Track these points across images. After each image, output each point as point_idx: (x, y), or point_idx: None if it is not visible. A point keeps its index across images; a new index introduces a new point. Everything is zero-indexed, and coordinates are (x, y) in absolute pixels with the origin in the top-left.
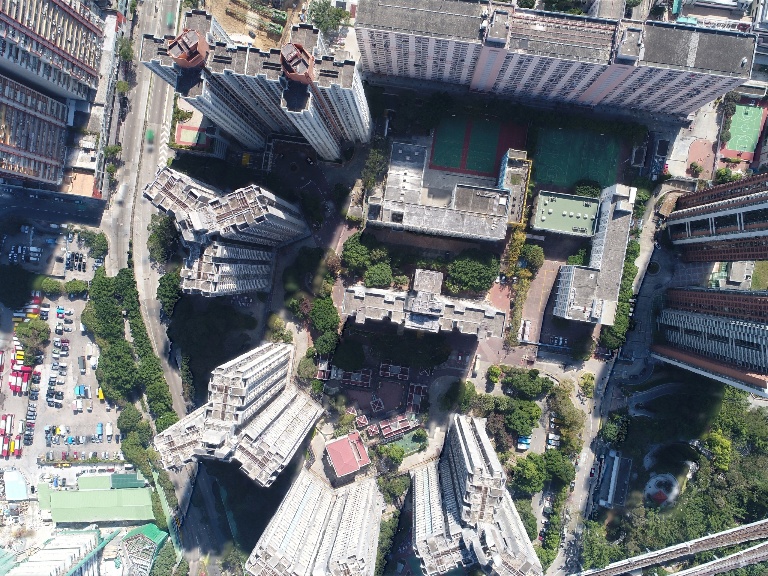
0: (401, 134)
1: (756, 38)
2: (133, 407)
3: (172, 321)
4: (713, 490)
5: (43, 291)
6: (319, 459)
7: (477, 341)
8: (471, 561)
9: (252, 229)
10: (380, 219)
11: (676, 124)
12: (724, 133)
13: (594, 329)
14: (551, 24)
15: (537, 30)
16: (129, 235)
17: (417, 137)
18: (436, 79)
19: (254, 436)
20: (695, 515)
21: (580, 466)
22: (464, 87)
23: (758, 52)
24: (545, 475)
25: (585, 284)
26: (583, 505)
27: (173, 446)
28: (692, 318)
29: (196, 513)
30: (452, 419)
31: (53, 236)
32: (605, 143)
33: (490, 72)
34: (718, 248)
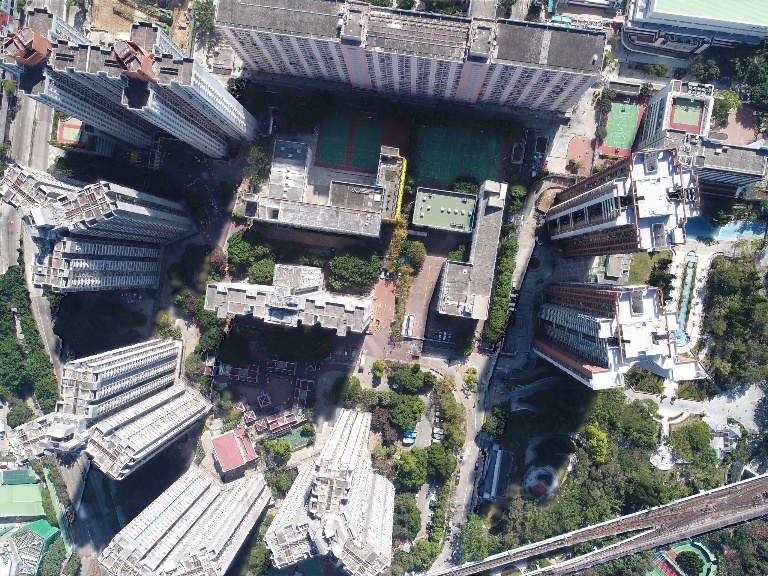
0: (286, 132)
1: (606, 36)
2: (24, 404)
3: (58, 318)
4: (589, 482)
5: None
6: (209, 454)
7: (363, 336)
8: None
9: (106, 225)
10: (257, 216)
11: (555, 121)
12: (600, 130)
13: (477, 324)
14: (407, 22)
15: (393, 28)
16: (20, 233)
17: (302, 135)
18: (318, 77)
19: (105, 430)
20: (571, 507)
21: (465, 460)
22: (348, 85)
23: (633, 50)
24: (429, 469)
25: (459, 279)
26: (468, 498)
27: (26, 440)
28: (557, 312)
29: (88, 509)
30: (338, 414)
31: None
32: (486, 140)
33: (361, 70)
34: (582, 243)
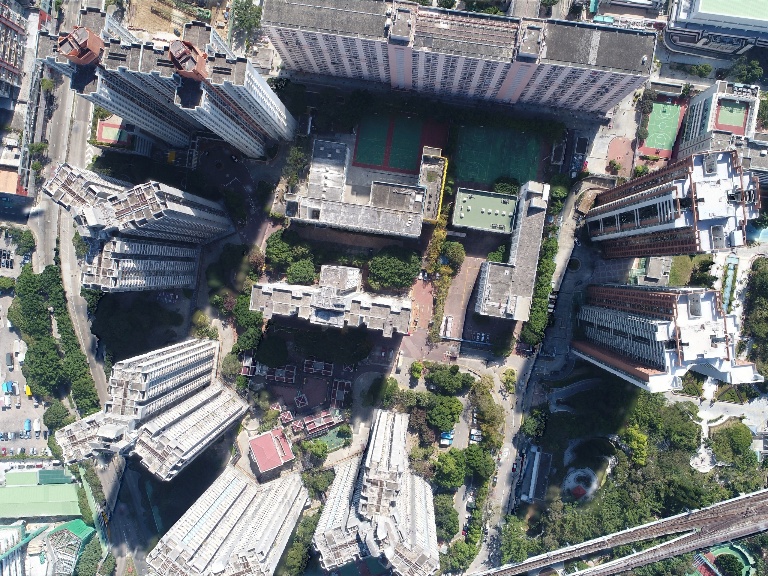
0: (325, 132)
1: (656, 36)
2: (60, 403)
3: (96, 317)
4: (629, 485)
5: None
6: (245, 455)
7: (401, 337)
8: None
9: (154, 225)
10: (298, 216)
11: (595, 122)
12: (641, 131)
13: (516, 325)
14: (455, 22)
15: (441, 28)
16: (56, 232)
17: (340, 135)
18: (357, 77)
19: (154, 430)
20: (611, 509)
21: (502, 461)
22: (387, 85)
23: (675, 51)
24: (467, 470)
25: (500, 280)
26: (506, 500)
27: (74, 440)
28: (601, 314)
29: (124, 509)
30: (375, 415)
31: None
32: (526, 141)
33: (404, 70)
34: (627, 244)
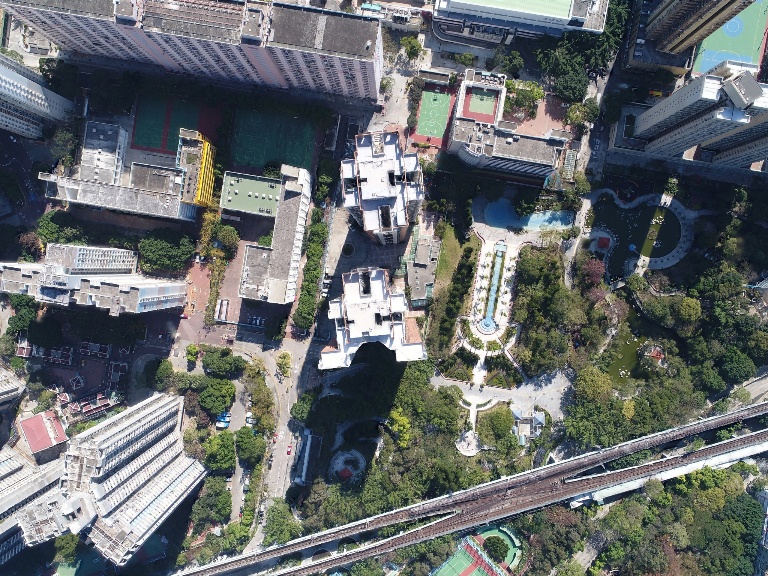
0: (103, 113)
1: (379, 22)
2: None
3: None
4: (391, 467)
5: None
6: None
7: (178, 320)
8: (68, 530)
9: None
10: (59, 196)
11: (369, 109)
12: (410, 118)
13: (291, 309)
14: (184, 3)
15: (171, 9)
16: None
17: (119, 117)
18: (132, 59)
19: None
20: (372, 491)
21: (278, 444)
22: (164, 68)
23: (444, 40)
24: (239, 452)
25: (258, 263)
26: (281, 482)
27: None
28: None
29: None
30: None
31: None
32: (301, 126)
33: (158, 52)
34: None
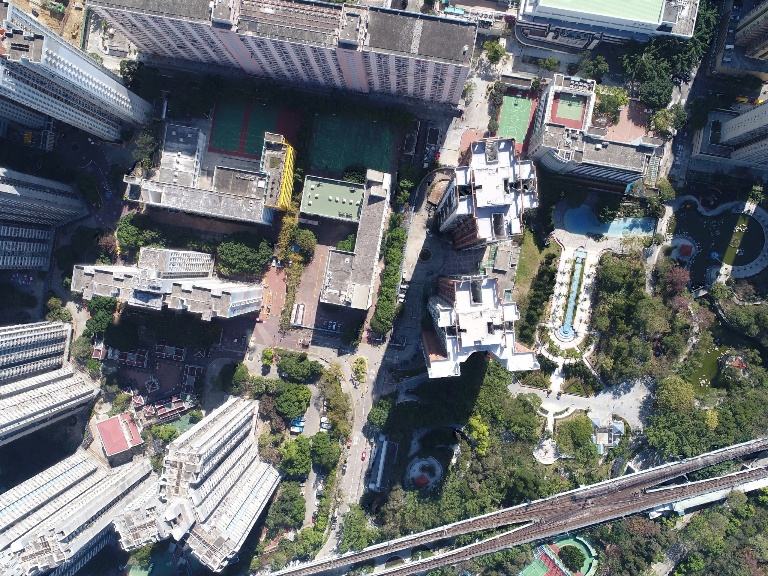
0: (181, 116)
1: (477, 27)
2: None
3: None
4: (469, 474)
5: None
6: None
7: (253, 324)
8: None
9: None
10: (142, 199)
11: (449, 113)
12: (491, 123)
13: (367, 314)
14: (280, 7)
15: (266, 13)
16: None
17: (197, 120)
18: (212, 62)
19: None
20: (450, 499)
21: (352, 450)
22: (243, 71)
23: (526, 44)
24: (314, 458)
25: (341, 268)
26: (355, 488)
27: None
28: (431, 303)
29: None
30: (226, 401)
31: None
32: (380, 130)
33: (245, 55)
34: (459, 234)
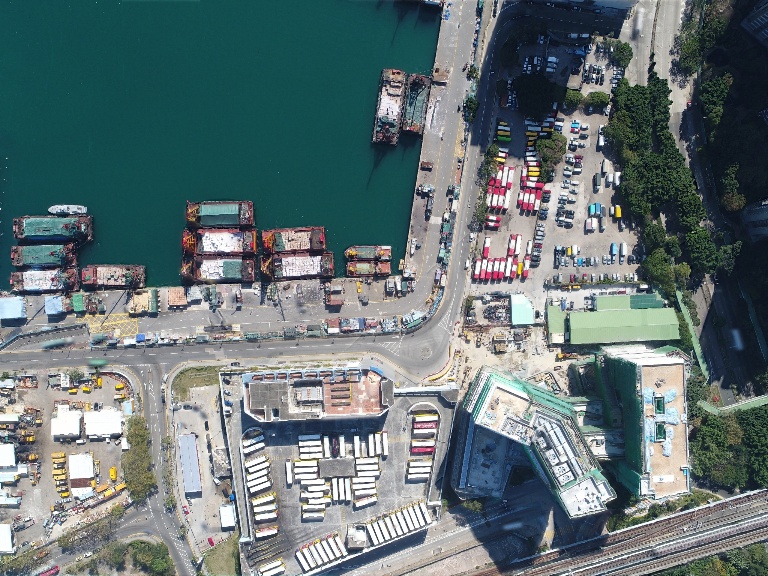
0: None
1: None
2: None
3: (717, 129)
4: None
5: (559, 104)
6: None
7: None
8: None
9: None
10: None
11: None
12: None
13: None
14: None
15: None
16: (650, 47)
17: None
18: None
19: None
20: None
21: None
22: None
23: None
24: None
25: None
26: None
27: None
28: None
29: (710, 336)
30: None
31: (569, 47)
32: None
33: None
34: None
